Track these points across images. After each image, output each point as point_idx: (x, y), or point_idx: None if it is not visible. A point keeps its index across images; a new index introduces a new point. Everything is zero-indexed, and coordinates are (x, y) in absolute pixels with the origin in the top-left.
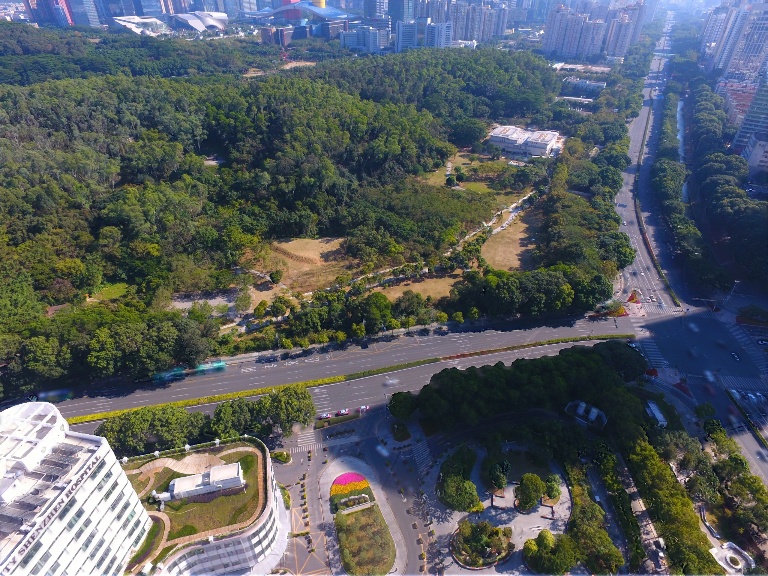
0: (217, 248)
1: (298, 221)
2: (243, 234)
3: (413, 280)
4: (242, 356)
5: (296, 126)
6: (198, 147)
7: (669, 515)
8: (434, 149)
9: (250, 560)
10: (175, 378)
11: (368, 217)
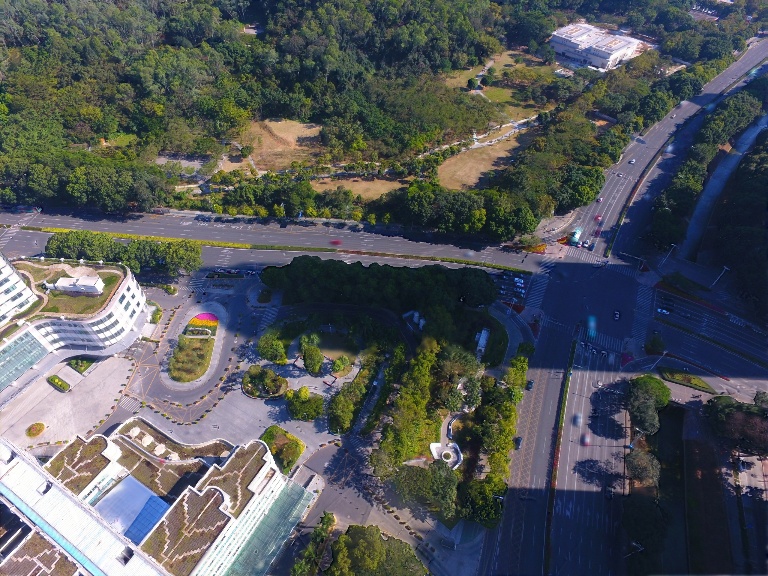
0: (212, 117)
1: (288, 103)
2: (236, 108)
3: (364, 178)
4: (187, 212)
5: (327, 2)
6: (242, 14)
7: (397, 405)
8: (475, 44)
9: (98, 341)
10: (133, 217)
11: (349, 109)
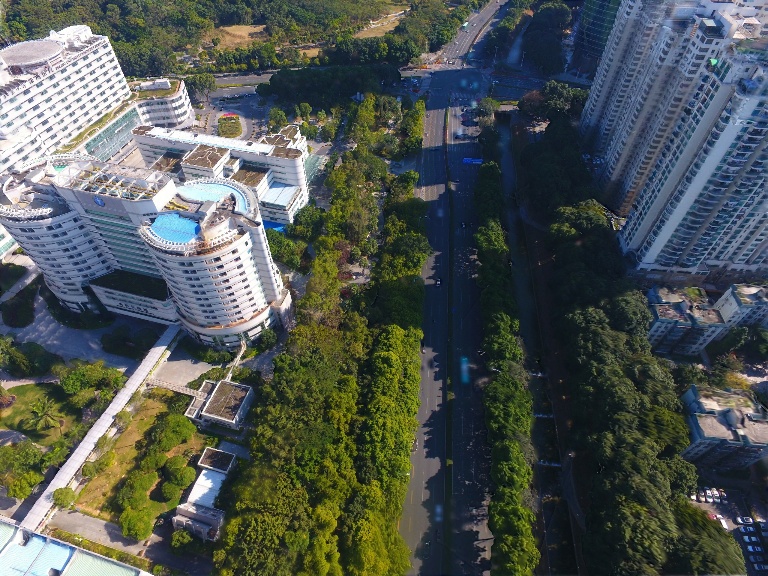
0: (181, 25)
1: (236, 11)
2: (198, 17)
3: (303, 49)
4: None
5: None
6: None
7: (358, 116)
8: None
9: (174, 118)
10: None
11: (282, 9)
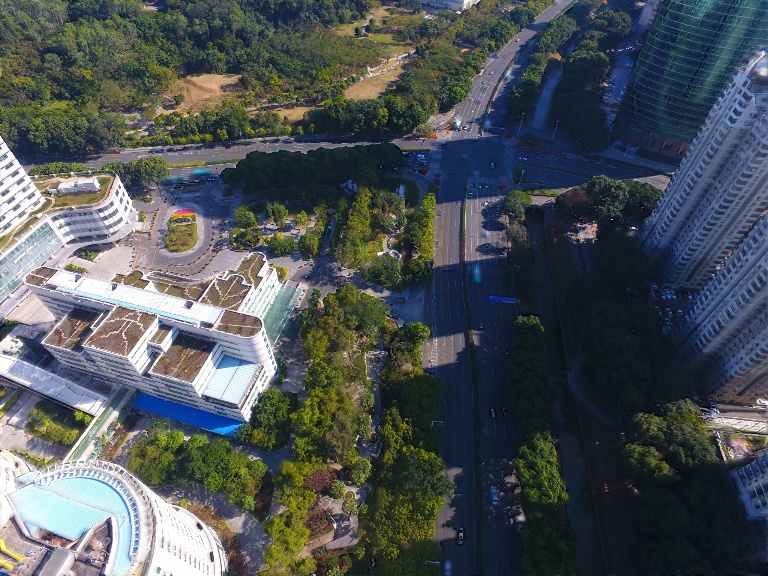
0: (138, 77)
1: (205, 58)
2: (159, 66)
3: (285, 107)
4: (140, 148)
5: None
6: None
7: (348, 226)
8: (355, 1)
9: (104, 229)
10: (92, 158)
11: (261, 56)
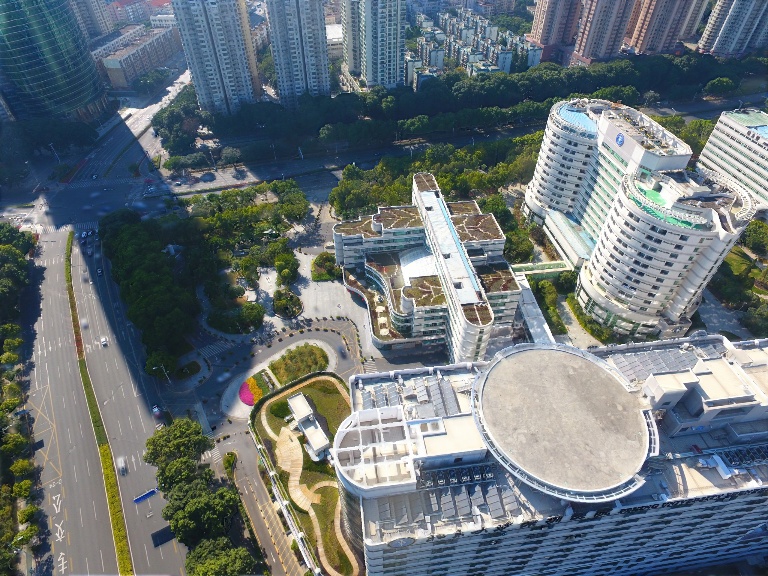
0: None
1: None
2: None
3: None
4: None
5: None
6: None
7: (259, 214)
8: None
9: None
10: None
11: None
